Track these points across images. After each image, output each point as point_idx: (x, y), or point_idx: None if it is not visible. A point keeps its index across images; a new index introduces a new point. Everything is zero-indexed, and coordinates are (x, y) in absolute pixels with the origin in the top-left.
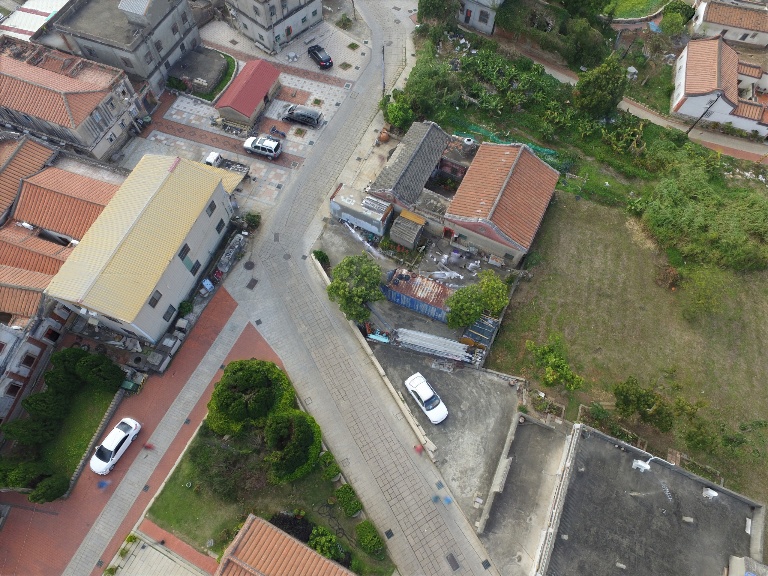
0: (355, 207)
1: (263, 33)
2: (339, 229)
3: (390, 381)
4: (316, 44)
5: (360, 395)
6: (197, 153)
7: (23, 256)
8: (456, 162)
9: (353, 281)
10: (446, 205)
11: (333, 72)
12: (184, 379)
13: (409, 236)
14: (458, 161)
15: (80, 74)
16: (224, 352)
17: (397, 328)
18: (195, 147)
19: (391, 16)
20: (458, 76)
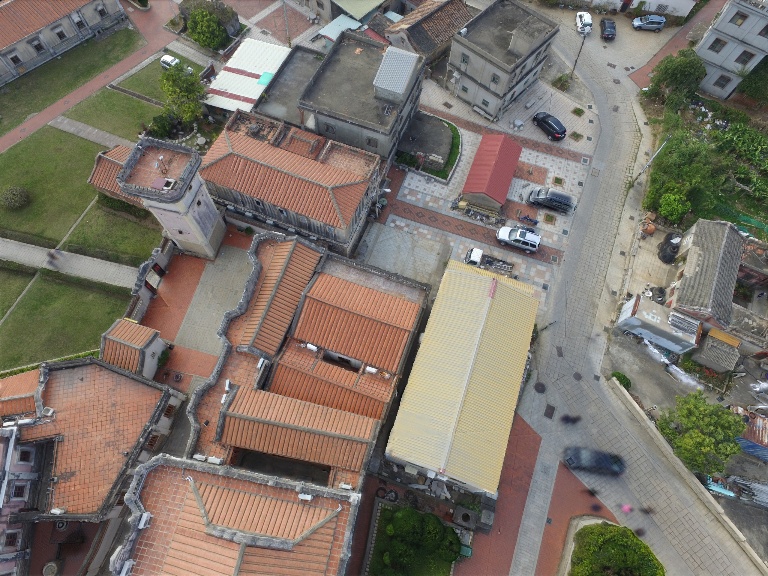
0: (662, 326)
1: (492, 100)
2: (625, 342)
3: (751, 547)
4: (537, 109)
5: (718, 563)
6: (445, 243)
7: (318, 387)
8: (758, 270)
9: (719, 436)
10: (762, 325)
11: (565, 143)
12: (512, 537)
13: (728, 362)
14: (760, 268)
15: (329, 158)
16: (545, 501)
17: (728, 472)
18: (441, 236)
19: (608, 75)
20: (710, 153)
